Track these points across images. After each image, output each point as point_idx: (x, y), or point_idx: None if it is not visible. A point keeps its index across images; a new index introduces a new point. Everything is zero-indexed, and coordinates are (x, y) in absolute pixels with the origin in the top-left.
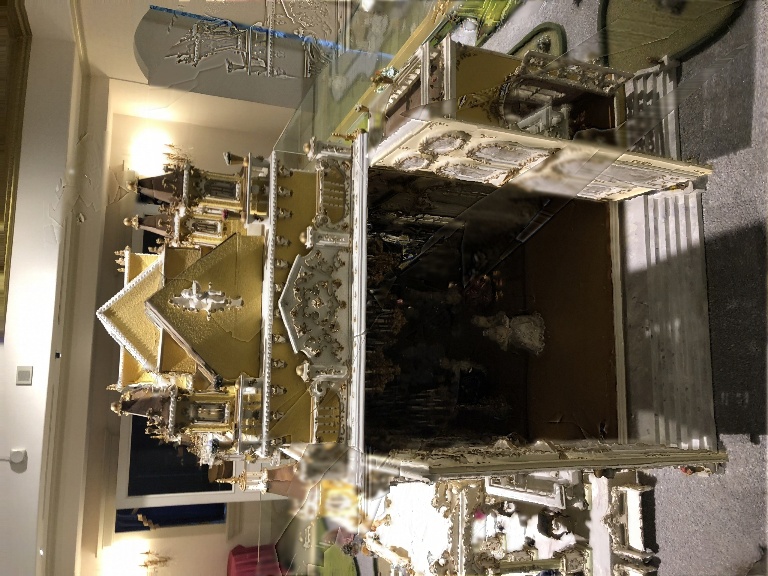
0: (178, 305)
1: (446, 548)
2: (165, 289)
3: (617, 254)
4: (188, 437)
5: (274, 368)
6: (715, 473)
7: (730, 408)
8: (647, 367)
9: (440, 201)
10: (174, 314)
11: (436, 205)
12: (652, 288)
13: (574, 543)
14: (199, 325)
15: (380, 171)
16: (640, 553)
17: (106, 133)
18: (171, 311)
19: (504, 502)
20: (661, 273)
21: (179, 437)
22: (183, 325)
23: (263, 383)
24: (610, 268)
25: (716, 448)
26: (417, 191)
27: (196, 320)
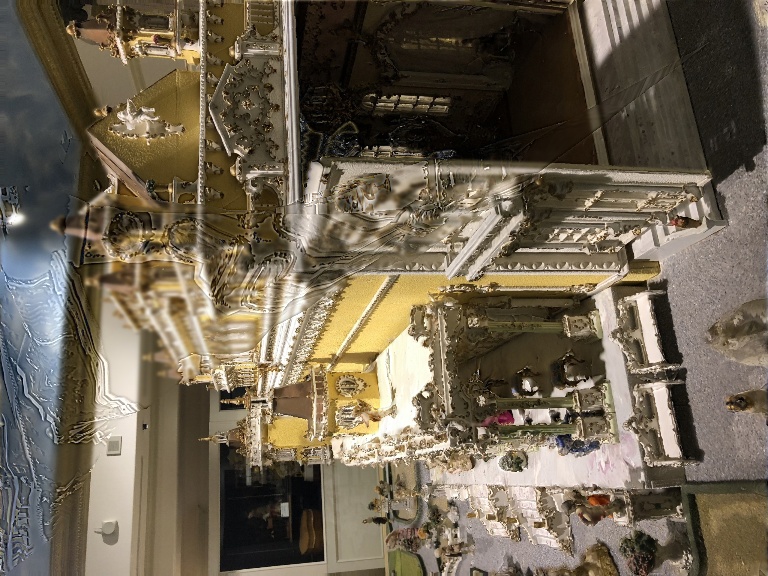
0: (117, 132)
1: (430, 381)
2: (105, 119)
3: (583, 54)
4: (238, 439)
5: (210, 174)
6: (716, 226)
7: (720, 151)
8: (629, 150)
9: (408, 70)
10: (114, 141)
11: (404, 74)
12: (621, 68)
13: (592, 386)
14: (140, 151)
15: (320, 7)
16: (660, 364)
17: (106, 89)
18: (111, 138)
19: (522, 380)
20: (627, 49)
21: (229, 440)
22: (124, 151)
23: (197, 185)
24: (578, 70)
25: (715, 203)
26: (369, 38)
27: (137, 146)
